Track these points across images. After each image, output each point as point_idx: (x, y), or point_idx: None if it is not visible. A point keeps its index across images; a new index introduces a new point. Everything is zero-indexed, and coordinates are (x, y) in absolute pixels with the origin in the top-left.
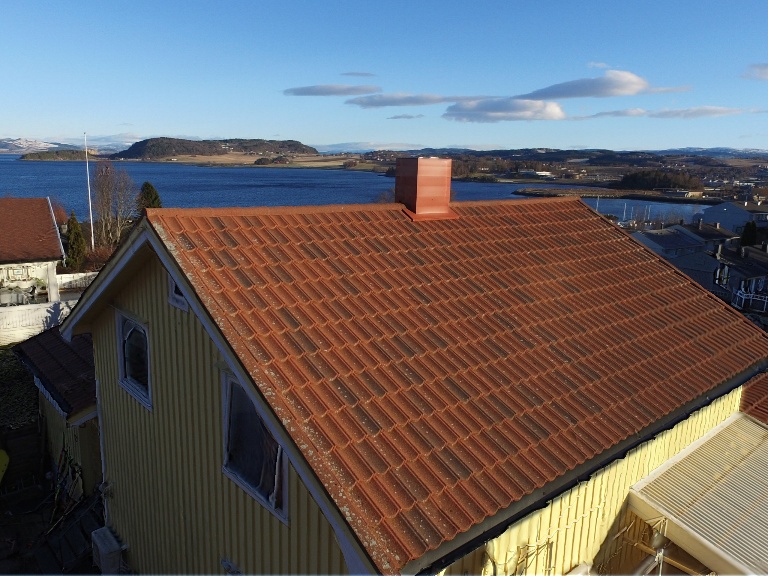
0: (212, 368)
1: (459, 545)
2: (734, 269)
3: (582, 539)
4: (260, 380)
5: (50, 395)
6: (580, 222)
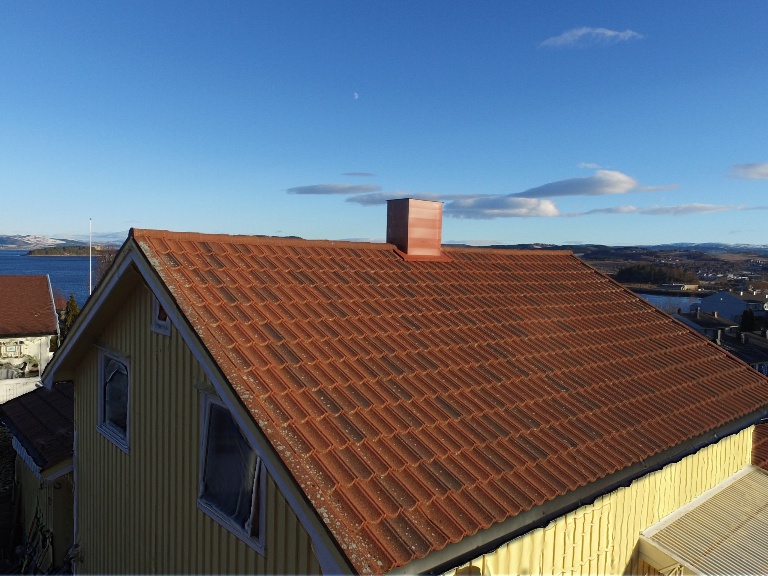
0: (191, 392)
1: (450, 558)
2: (736, 354)
3: None
4: (237, 384)
5: (27, 455)
6: (574, 273)
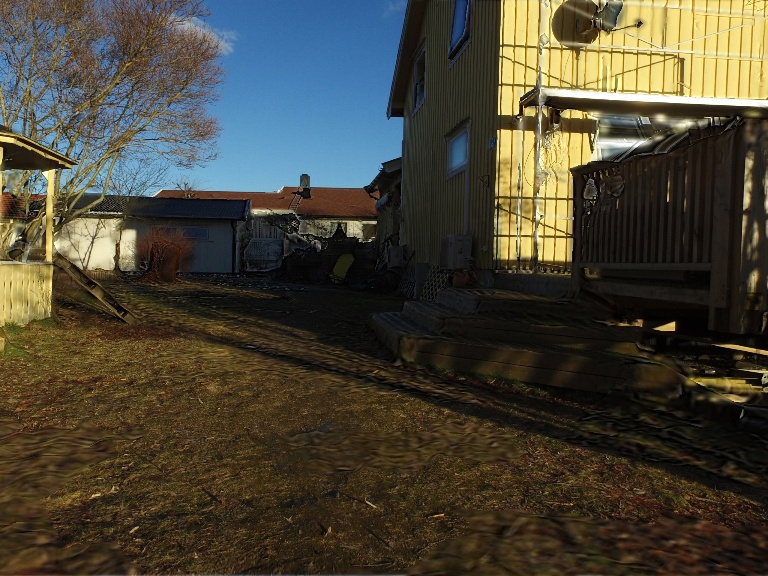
0: (448, 5)
1: None
2: None
3: (728, 81)
4: None
5: None
6: None
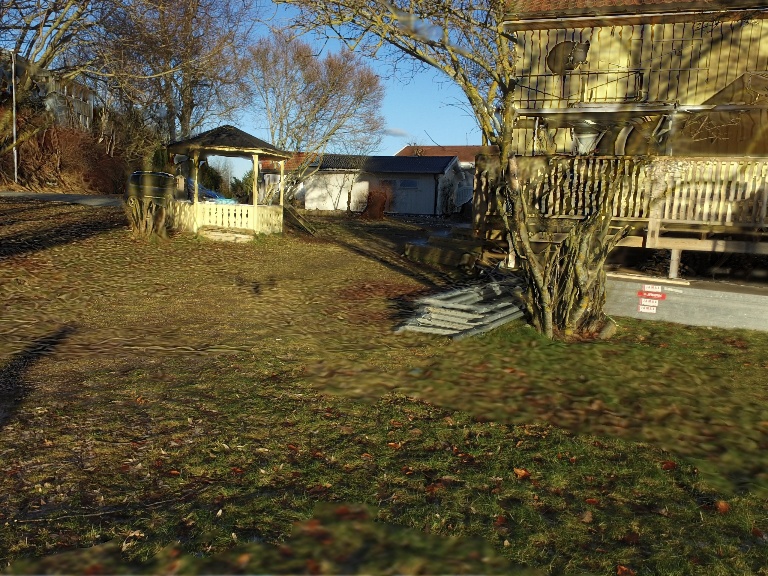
0: None
1: None
2: None
3: (679, 86)
4: None
5: None
6: None
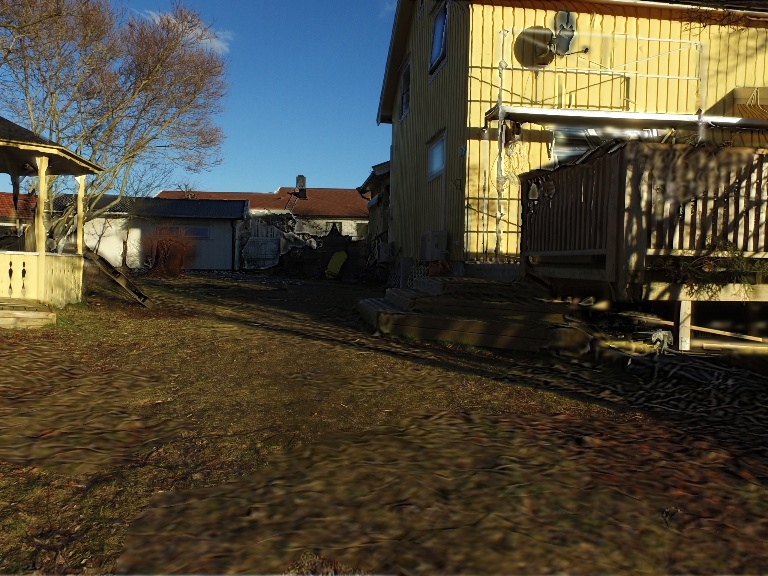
0: None
1: None
2: None
3: (669, 97)
4: None
5: None
6: None
